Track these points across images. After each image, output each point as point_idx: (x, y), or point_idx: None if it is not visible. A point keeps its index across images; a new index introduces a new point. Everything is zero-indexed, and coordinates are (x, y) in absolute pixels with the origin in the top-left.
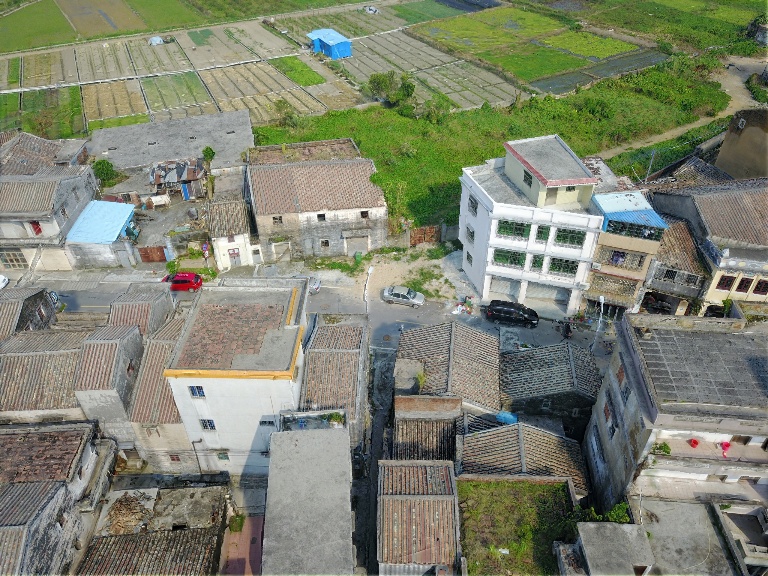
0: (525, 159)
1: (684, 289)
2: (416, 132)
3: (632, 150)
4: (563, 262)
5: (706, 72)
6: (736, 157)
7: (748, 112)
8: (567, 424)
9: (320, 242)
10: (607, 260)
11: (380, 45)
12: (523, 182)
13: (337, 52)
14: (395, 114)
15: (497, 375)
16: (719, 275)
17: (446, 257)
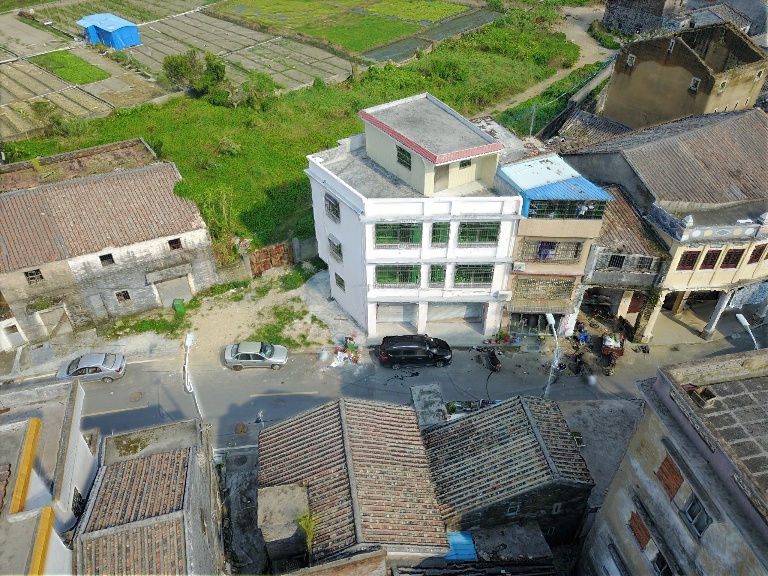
0: (394, 130)
1: (635, 277)
2: (236, 123)
3: (498, 113)
4: (473, 268)
5: (547, 23)
6: (629, 102)
7: (637, 44)
8: (545, 525)
9: (115, 296)
10: (532, 256)
11: (176, 29)
12: (397, 163)
13: (120, 39)
14: (205, 104)
15: (428, 477)
16: (680, 252)
17: (306, 284)
